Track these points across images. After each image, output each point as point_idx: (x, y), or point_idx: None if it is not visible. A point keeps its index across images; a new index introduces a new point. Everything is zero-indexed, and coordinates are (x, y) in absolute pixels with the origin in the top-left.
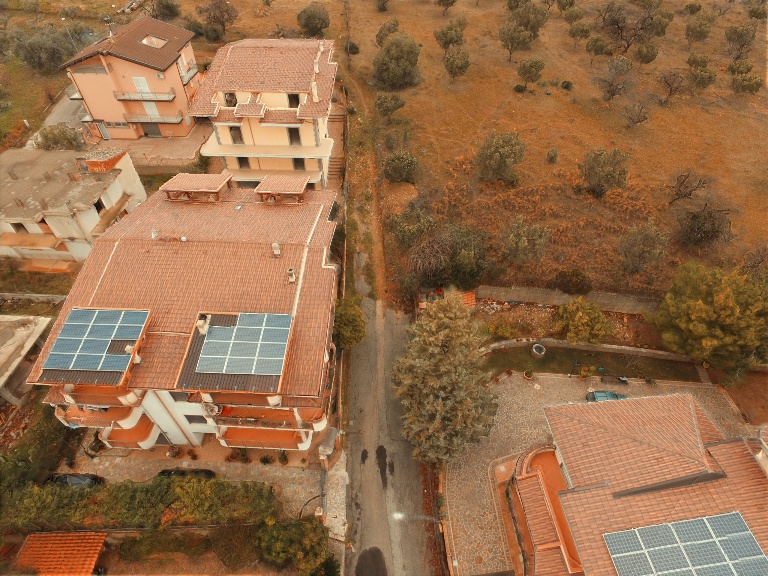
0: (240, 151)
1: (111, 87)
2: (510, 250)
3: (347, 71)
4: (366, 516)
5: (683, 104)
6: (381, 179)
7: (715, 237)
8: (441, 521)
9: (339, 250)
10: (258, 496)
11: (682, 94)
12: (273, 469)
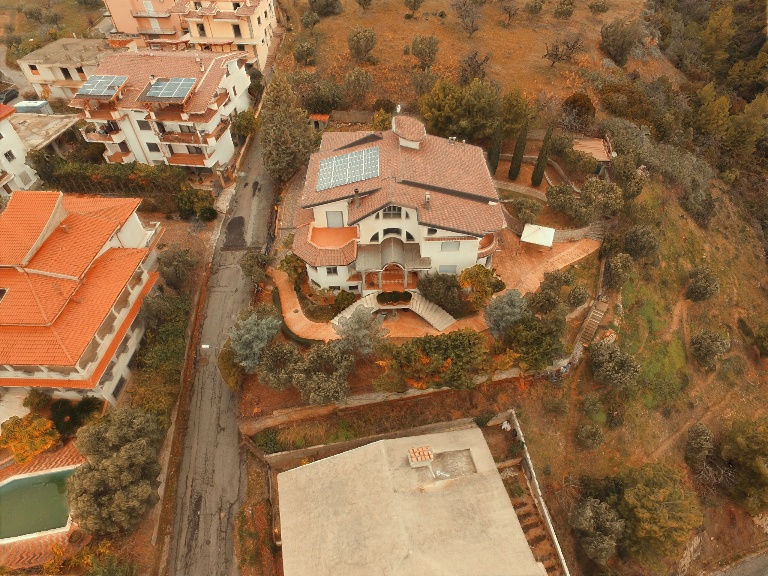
0: (203, 40)
1: (129, 7)
2: (347, 85)
3: (293, 6)
4: (240, 206)
5: (520, 27)
6: (296, 65)
7: (472, 81)
8: (278, 206)
9: (255, 95)
10: None
11: (524, 21)
12: (195, 186)
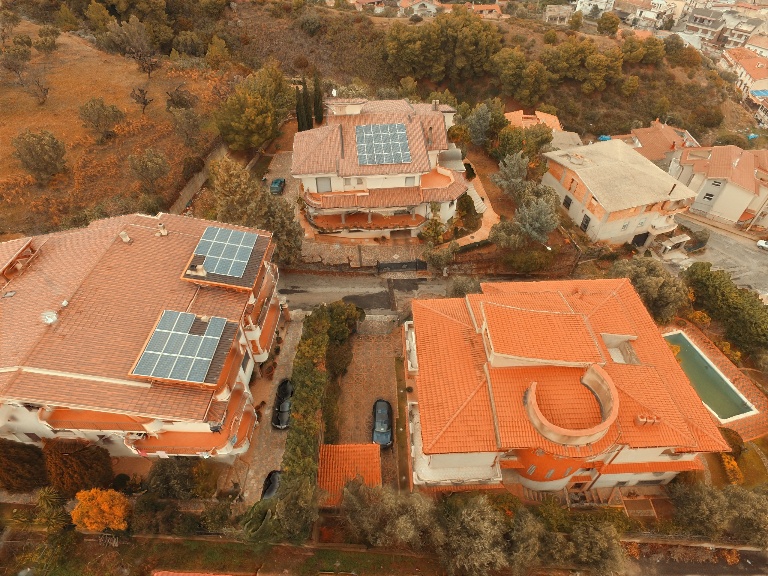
0: None
1: None
2: (157, 173)
3: None
4: None
5: None
6: None
7: (194, 101)
8: None
9: None
10: (316, 312)
11: None
12: (284, 350)
